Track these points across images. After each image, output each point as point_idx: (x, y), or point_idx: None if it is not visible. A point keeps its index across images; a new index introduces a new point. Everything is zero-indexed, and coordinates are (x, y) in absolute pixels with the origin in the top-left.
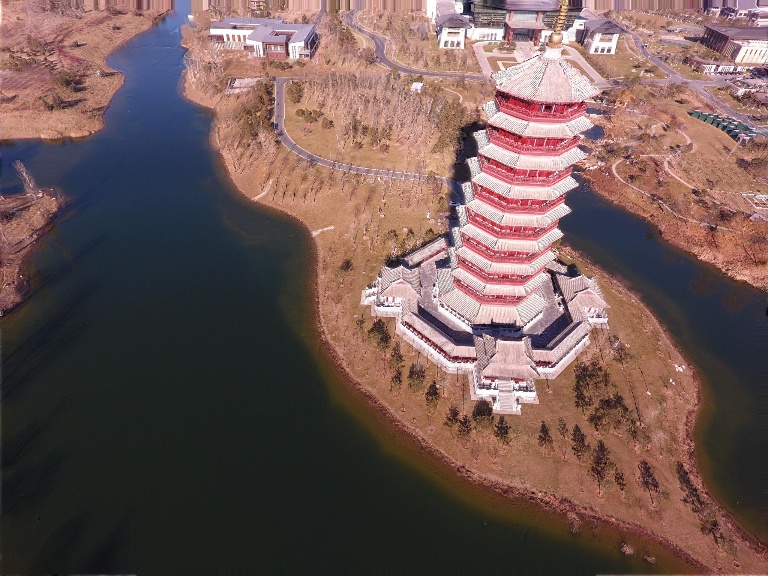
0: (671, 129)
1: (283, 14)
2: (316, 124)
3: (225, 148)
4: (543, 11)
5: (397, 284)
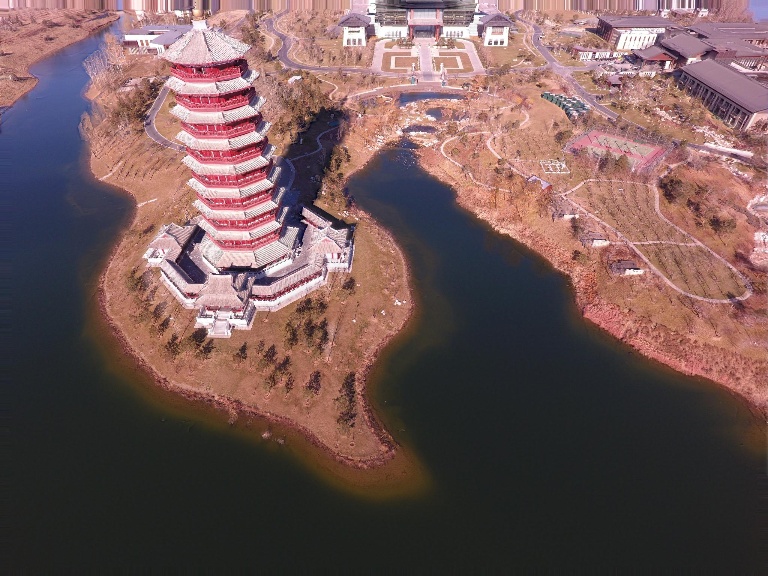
0: (516, 109)
1: None
2: None
3: None
4: (440, 8)
5: (163, 237)
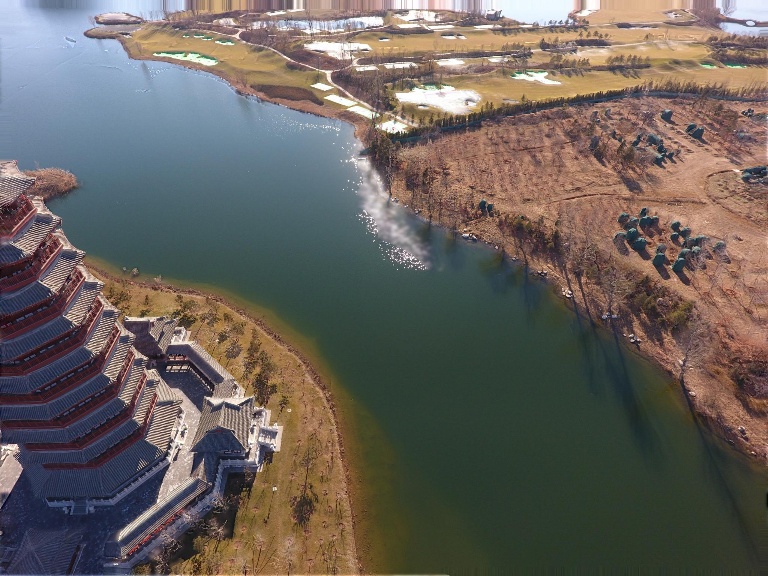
0: None
1: None
2: None
3: None
4: None
5: None
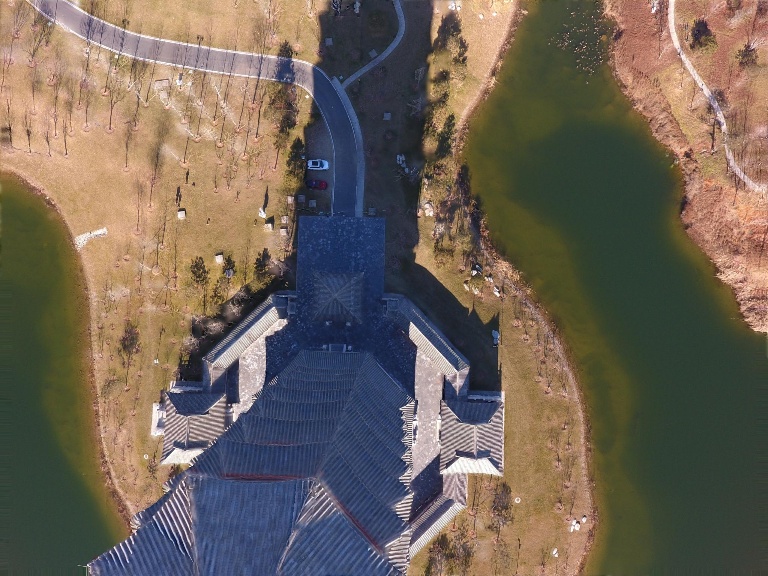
0: None
1: None
2: None
3: None
4: None
5: None
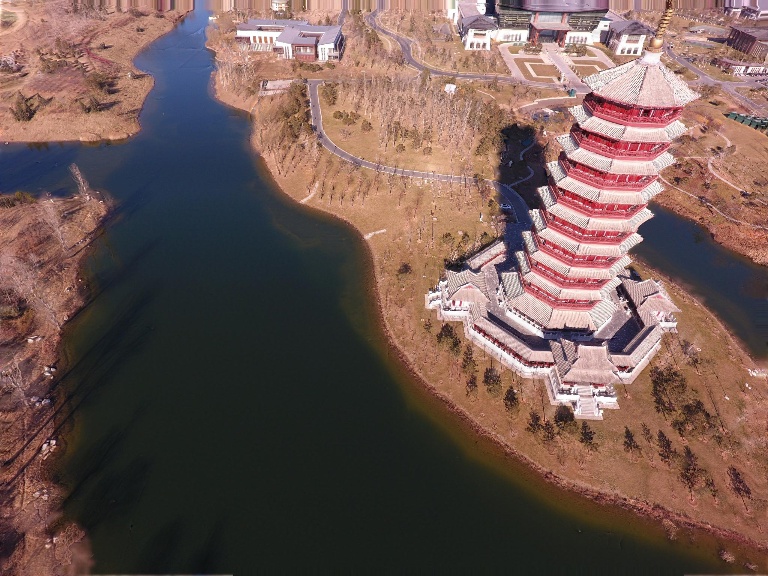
0: (709, 131)
1: (305, 15)
2: (354, 126)
3: (266, 150)
4: (569, 12)
5: (465, 288)
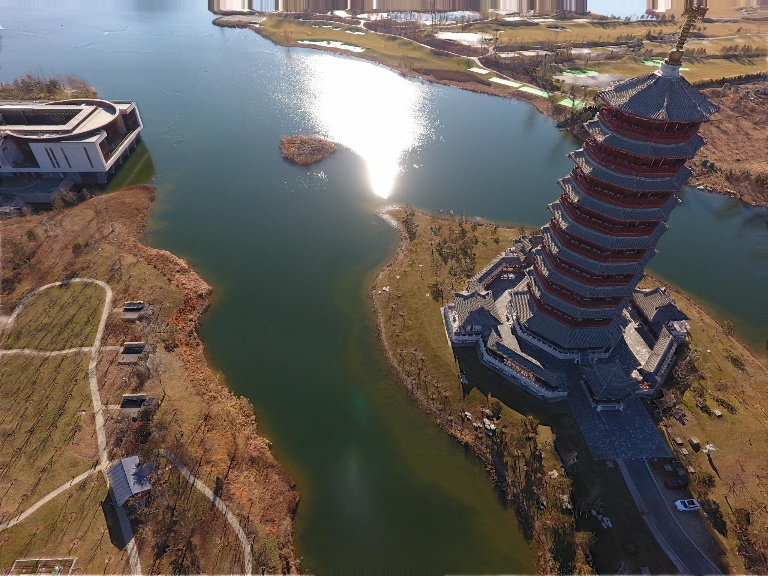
0: None
1: None
2: None
3: None
4: None
5: None
